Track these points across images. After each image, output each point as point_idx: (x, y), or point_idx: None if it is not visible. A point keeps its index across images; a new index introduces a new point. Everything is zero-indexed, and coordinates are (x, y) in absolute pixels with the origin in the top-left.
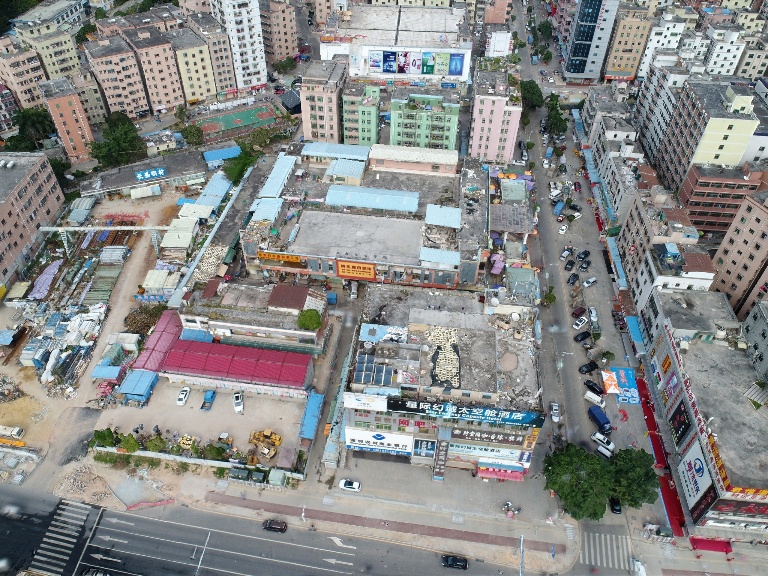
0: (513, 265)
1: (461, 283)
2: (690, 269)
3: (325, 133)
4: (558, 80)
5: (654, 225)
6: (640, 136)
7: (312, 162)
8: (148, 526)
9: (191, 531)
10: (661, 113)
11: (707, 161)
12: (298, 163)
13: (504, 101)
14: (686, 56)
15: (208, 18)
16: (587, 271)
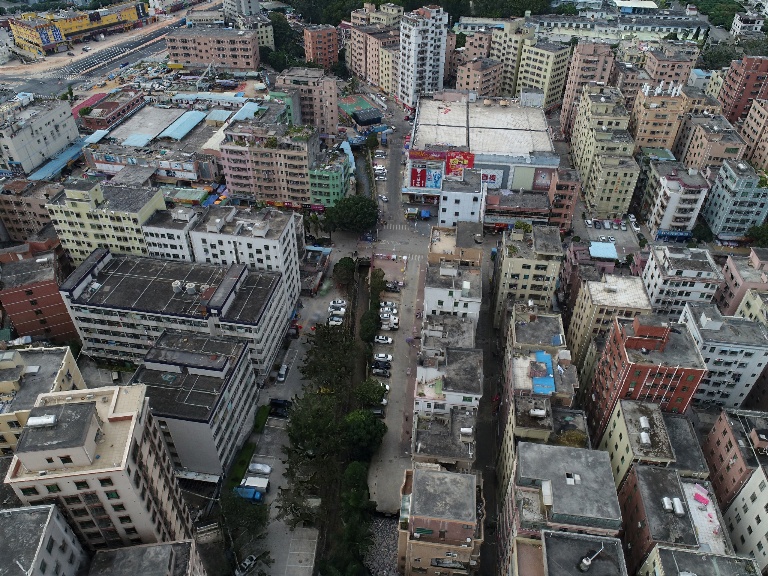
0: None
1: None
2: None
3: None
4: None
5: None
6: None
7: None
8: None
9: None
10: None
11: None
12: None
13: None
14: None
15: None
16: None
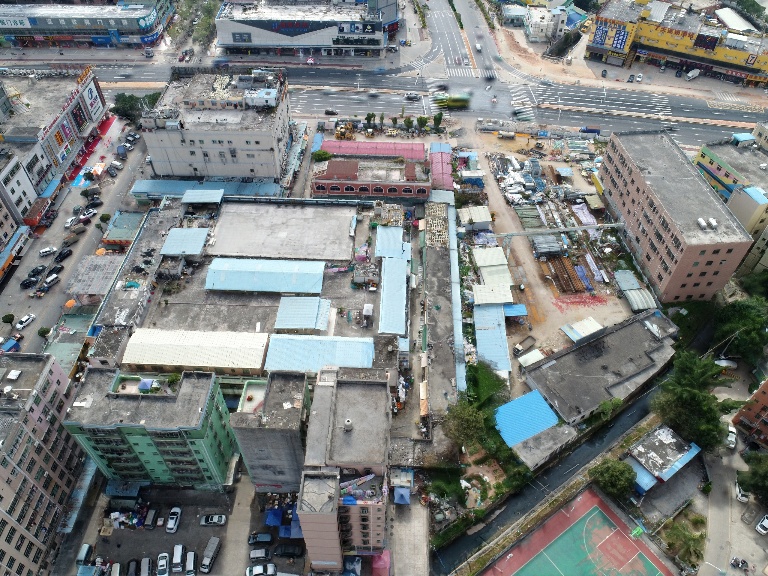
0: None
1: None
2: None
3: None
4: None
5: None
6: None
7: None
8: (397, 111)
9: (374, 111)
10: None
11: None
12: None
13: None
14: None
15: None
16: None
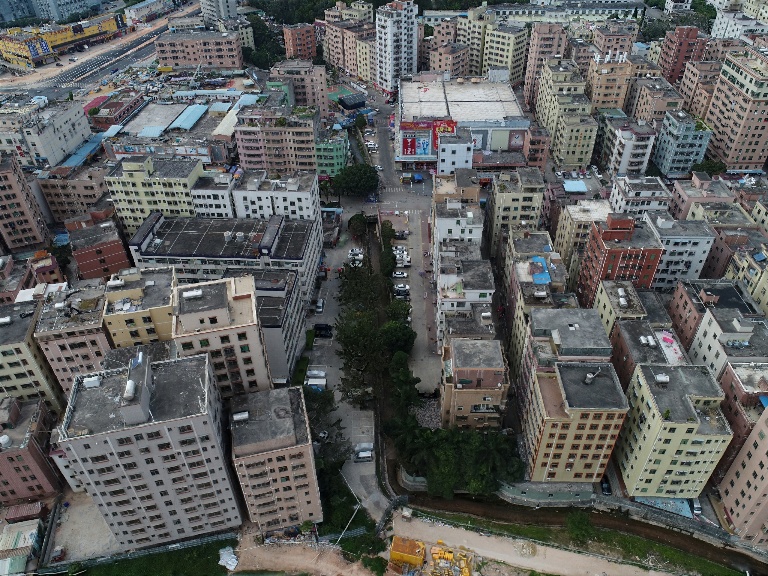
0: None
1: None
2: None
3: None
4: None
5: None
6: None
7: None
8: None
9: None
10: None
11: None
12: None
13: None
14: None
15: None
16: None
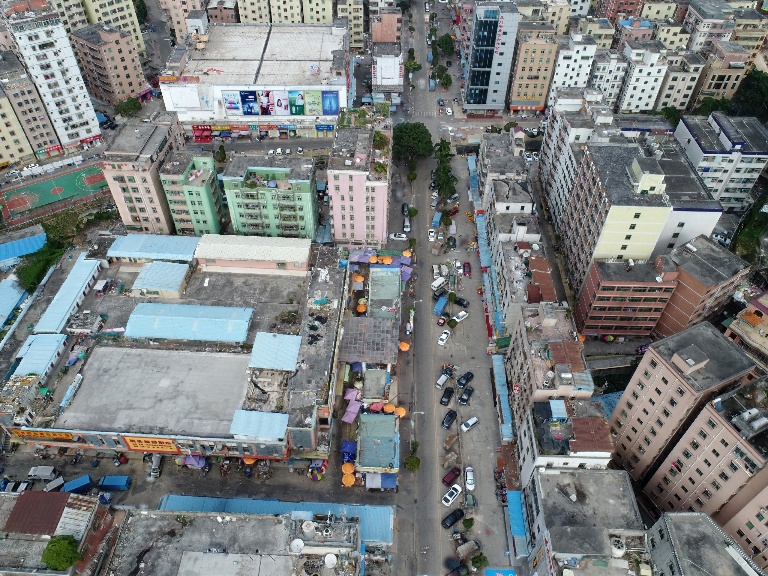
0: (372, 406)
1: (296, 449)
2: (579, 447)
3: (148, 217)
4: (458, 111)
5: (538, 369)
6: (544, 193)
7: (124, 263)
8: None
9: None
10: (563, 174)
11: (613, 252)
12: (105, 266)
13: (363, 176)
14: (592, 99)
15: (11, 59)
16: (468, 404)
